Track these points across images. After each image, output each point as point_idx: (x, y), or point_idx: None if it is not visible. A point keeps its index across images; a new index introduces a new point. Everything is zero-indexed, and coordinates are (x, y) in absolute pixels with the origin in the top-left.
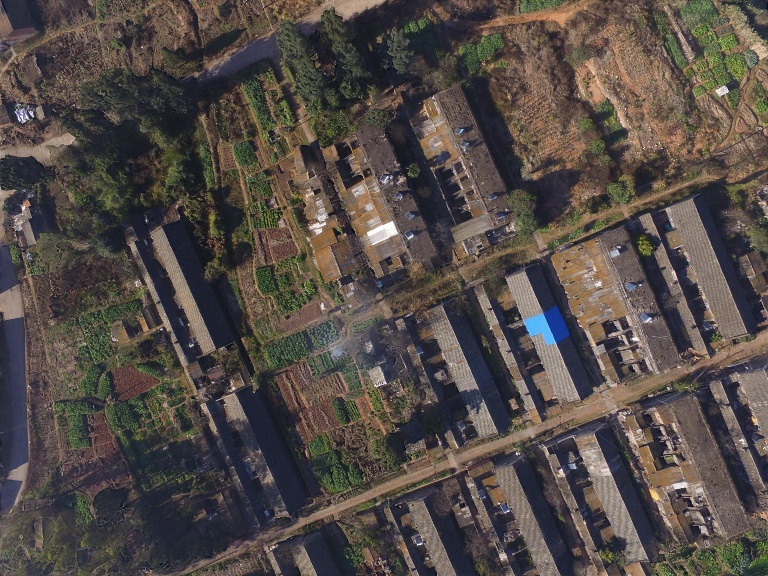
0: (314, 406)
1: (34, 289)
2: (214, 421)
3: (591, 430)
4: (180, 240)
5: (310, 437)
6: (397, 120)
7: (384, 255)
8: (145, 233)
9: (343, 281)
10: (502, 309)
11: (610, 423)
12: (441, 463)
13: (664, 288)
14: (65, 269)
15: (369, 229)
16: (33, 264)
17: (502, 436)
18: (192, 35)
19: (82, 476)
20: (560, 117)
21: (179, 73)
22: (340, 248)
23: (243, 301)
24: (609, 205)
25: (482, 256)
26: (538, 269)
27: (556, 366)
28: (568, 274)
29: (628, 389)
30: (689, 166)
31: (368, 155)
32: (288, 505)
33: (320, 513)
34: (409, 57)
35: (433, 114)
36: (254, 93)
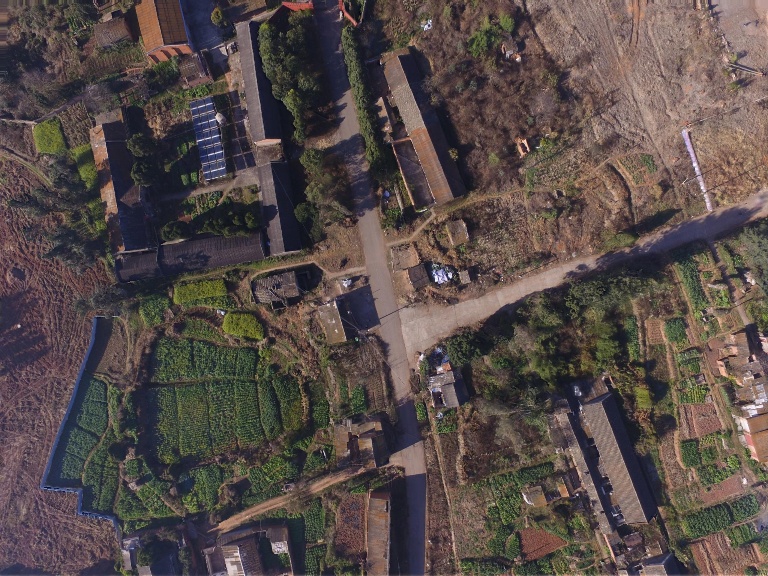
0: (726, 574)
1: (441, 447)
2: None
3: None
4: (613, 414)
5: None
6: None
7: None
8: (575, 404)
9: None
10: None
11: None
12: None
13: None
14: (481, 431)
15: None
16: (441, 422)
17: None
18: (626, 211)
19: None
20: None
21: (611, 247)
22: None
23: (662, 471)
24: None
25: None
26: None
27: None
28: None
29: None
30: None
31: None
32: None
33: None
34: None
35: None
36: (691, 274)
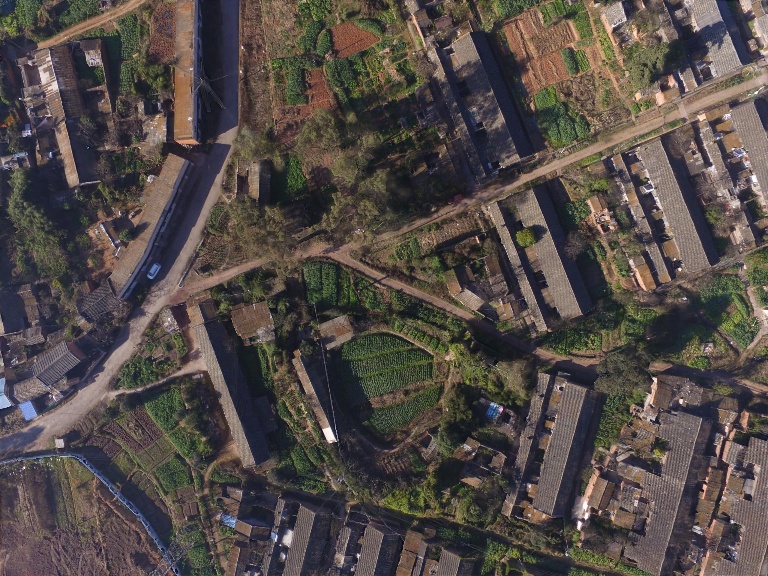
0: (542, 57)
1: None
2: (443, 67)
3: None
4: None
5: (537, 89)
6: None
7: None
8: None
9: None
10: None
11: None
12: (671, 113)
13: None
14: None
15: None
16: None
17: (737, 81)
18: None
19: (296, 135)
20: None
21: None
22: None
23: None
24: None
25: None
26: None
27: None
28: None
29: None
30: None
31: None
32: (518, 149)
33: (542, 169)
34: None
35: None
36: None
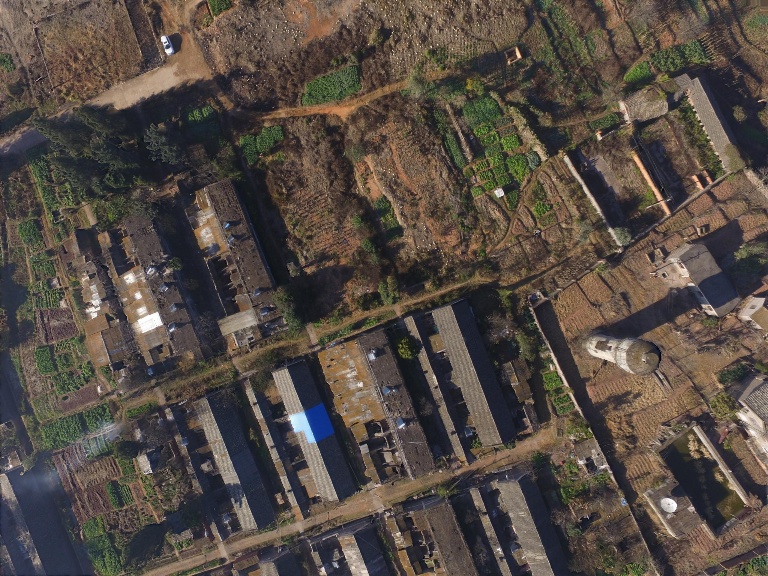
0: (89, 488)
1: None
2: None
3: (351, 530)
4: None
5: (85, 519)
6: (175, 208)
7: (152, 344)
8: None
9: (116, 366)
10: (269, 403)
11: (376, 522)
12: (212, 552)
13: (430, 390)
14: None
15: (139, 317)
16: None
17: (270, 529)
18: None
19: None
20: (336, 212)
21: None
22: (111, 334)
23: (24, 379)
24: (381, 303)
25: (255, 347)
26: (304, 365)
27: (317, 465)
28: (332, 372)
29: (395, 489)
30: (461, 268)
31: (135, 245)
32: None
33: None
34: (174, 151)
35: (203, 206)
36: (40, 173)
